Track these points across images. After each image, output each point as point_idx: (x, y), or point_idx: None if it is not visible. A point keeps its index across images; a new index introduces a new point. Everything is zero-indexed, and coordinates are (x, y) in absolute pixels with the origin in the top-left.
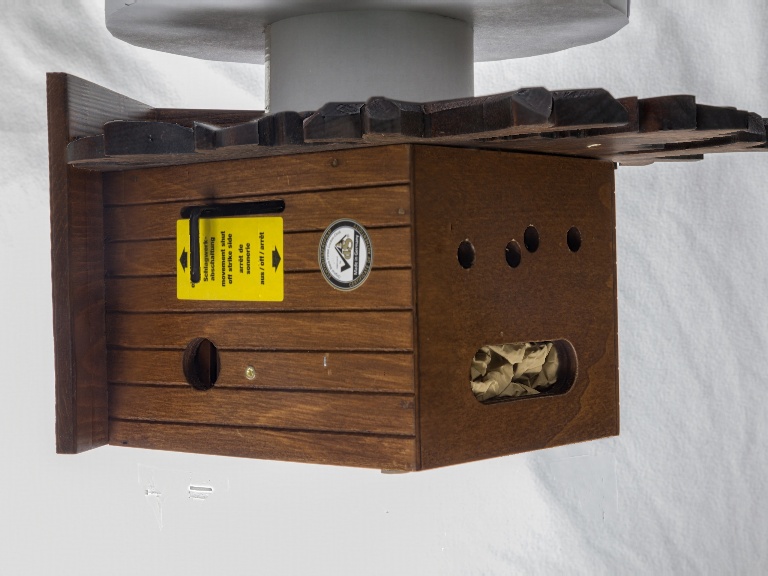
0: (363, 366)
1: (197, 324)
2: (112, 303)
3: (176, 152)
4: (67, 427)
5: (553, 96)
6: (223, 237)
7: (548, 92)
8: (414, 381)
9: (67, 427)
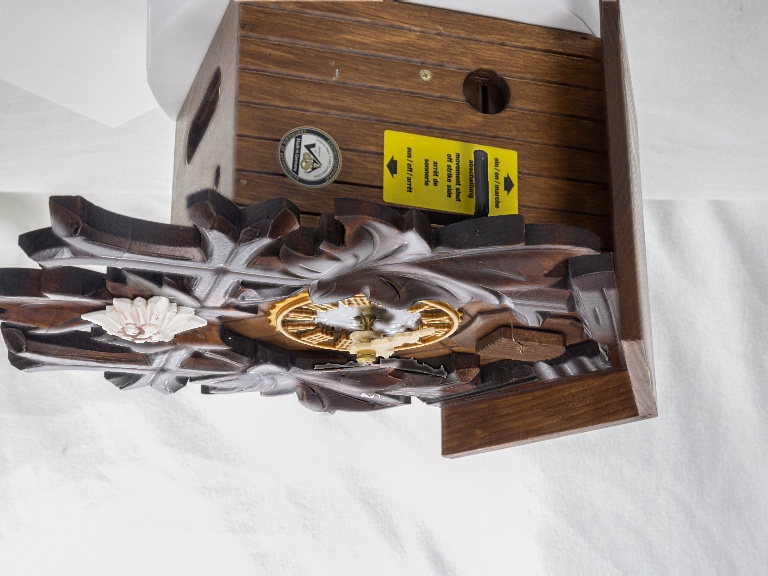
0: (294, 64)
1: (492, 126)
2: (603, 161)
3: (455, 225)
4: (607, 17)
5: (74, 250)
6: (458, 196)
7: (56, 230)
8: (239, 45)
9: (607, 17)
